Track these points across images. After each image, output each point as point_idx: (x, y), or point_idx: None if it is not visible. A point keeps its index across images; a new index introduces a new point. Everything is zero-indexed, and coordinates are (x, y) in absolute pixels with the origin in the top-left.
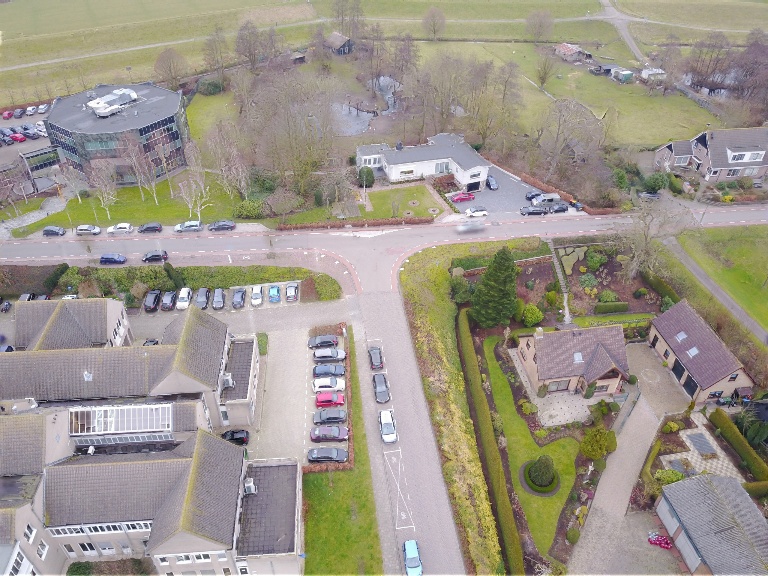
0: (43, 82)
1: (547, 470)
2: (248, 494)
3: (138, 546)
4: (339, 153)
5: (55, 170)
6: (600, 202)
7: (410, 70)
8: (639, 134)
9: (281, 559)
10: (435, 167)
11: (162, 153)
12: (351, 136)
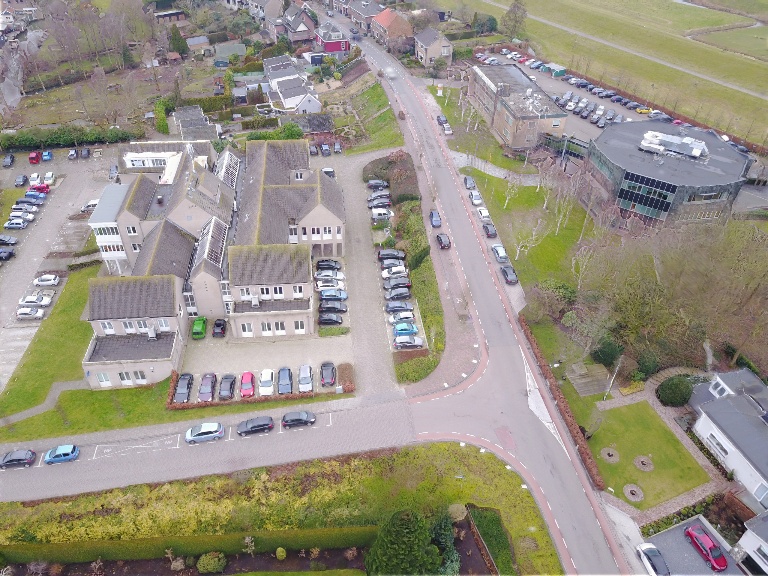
0: None
1: None
2: None
3: None
4: None
5: None
6: None
7: None
8: None
9: None
10: (759, 486)
11: None
12: None
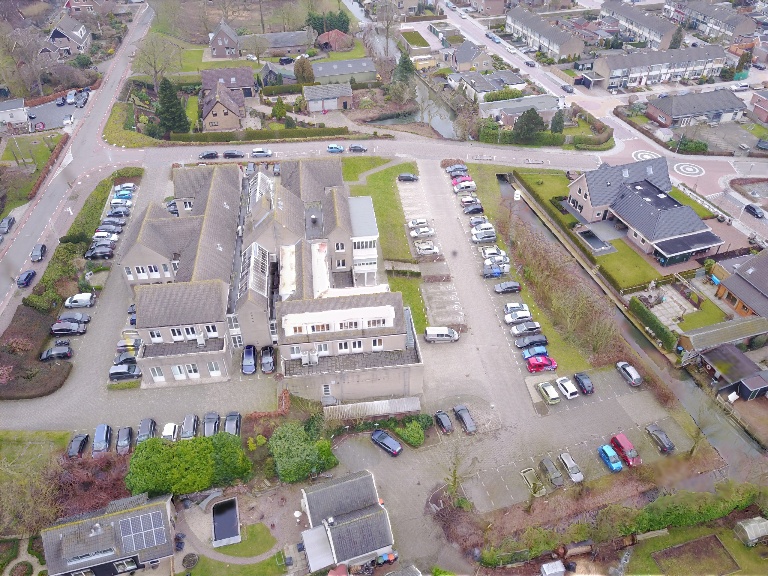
0: None
1: (293, 121)
2: None
3: None
4: None
5: None
6: (89, 81)
7: None
8: None
9: None
10: None
11: None
12: None
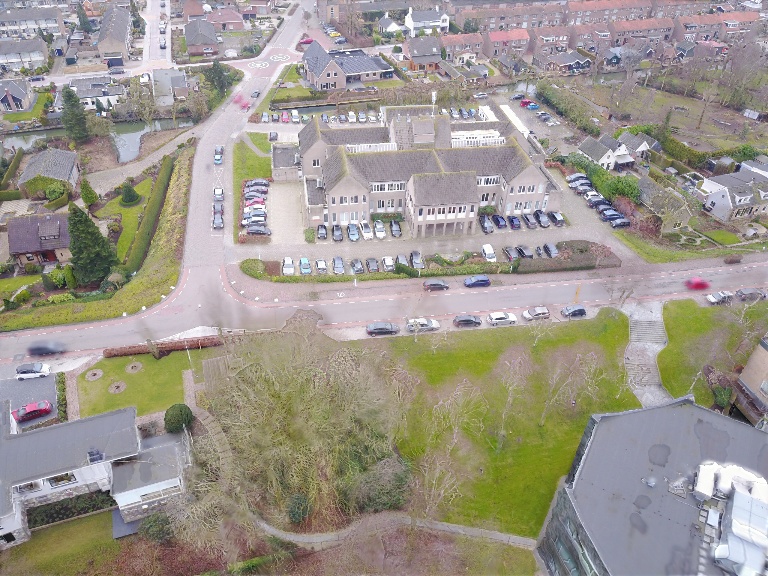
0: None
1: None
2: None
3: None
4: None
5: None
6: None
7: None
8: None
9: None
10: None
11: None
12: None
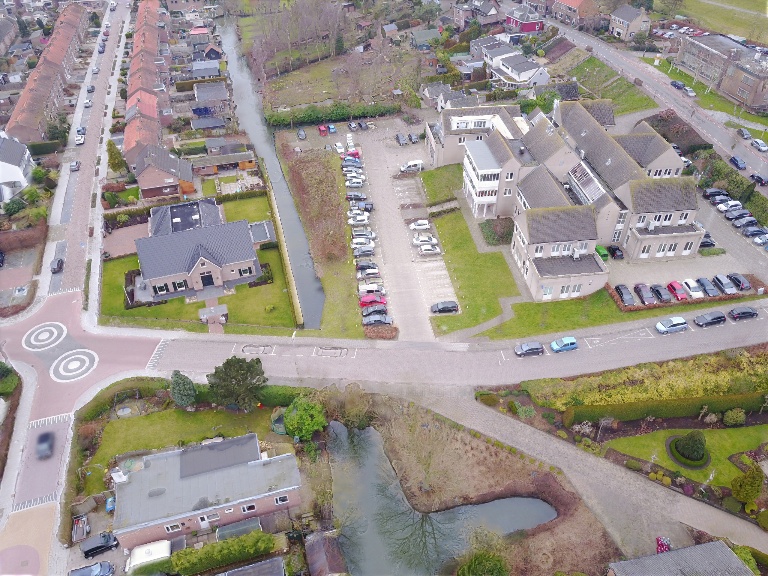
0: None
1: (689, 439)
2: (572, 257)
3: None
4: None
5: None
6: None
7: None
8: None
9: None
10: None
11: None
12: None
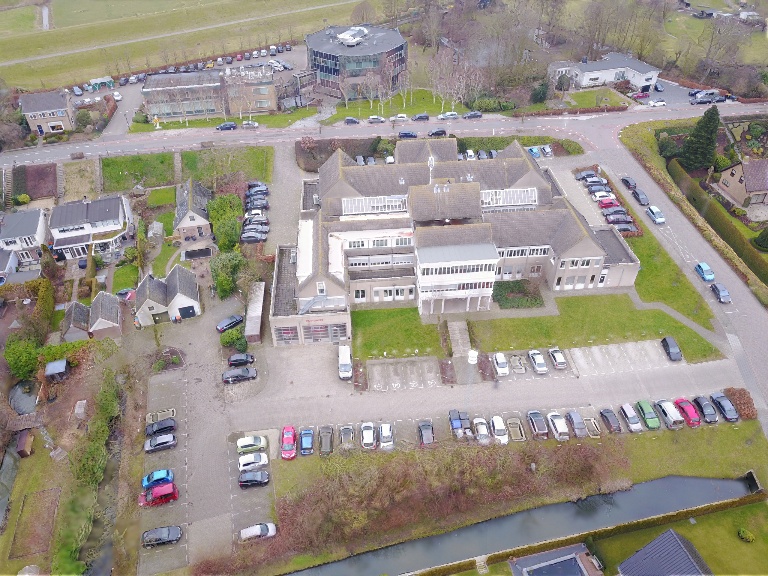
0: (246, 36)
1: None
2: None
3: (527, 271)
4: (519, 75)
5: (306, 91)
6: (750, 94)
7: (556, 14)
8: (753, 58)
9: (630, 267)
10: (615, 75)
11: (411, 68)
12: (521, 65)
